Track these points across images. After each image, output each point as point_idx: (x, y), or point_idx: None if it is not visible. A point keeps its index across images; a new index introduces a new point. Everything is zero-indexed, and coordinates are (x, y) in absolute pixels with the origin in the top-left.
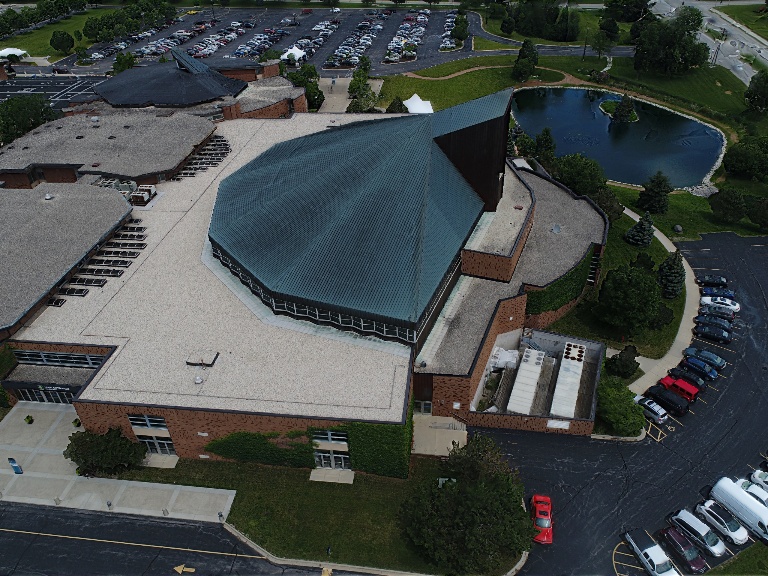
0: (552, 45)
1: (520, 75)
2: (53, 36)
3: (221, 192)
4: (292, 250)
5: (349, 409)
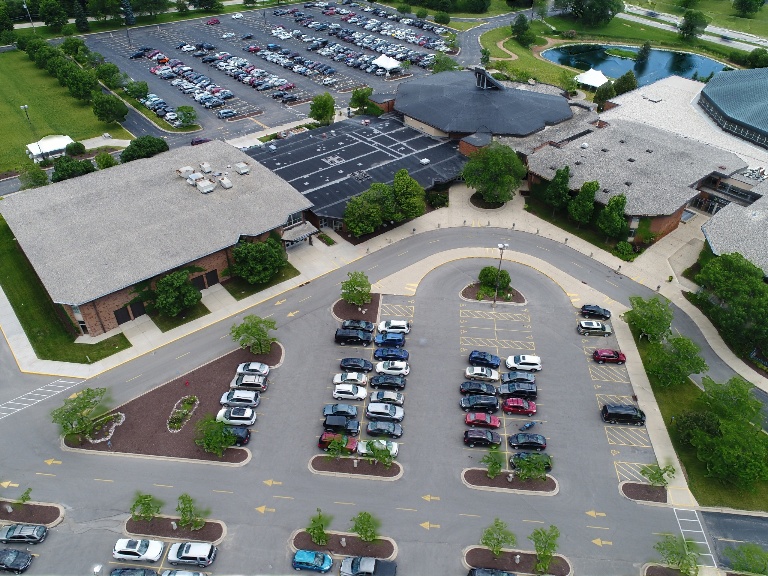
0: (489, 17)
1: (527, 44)
2: (106, 104)
3: None
4: None
5: None
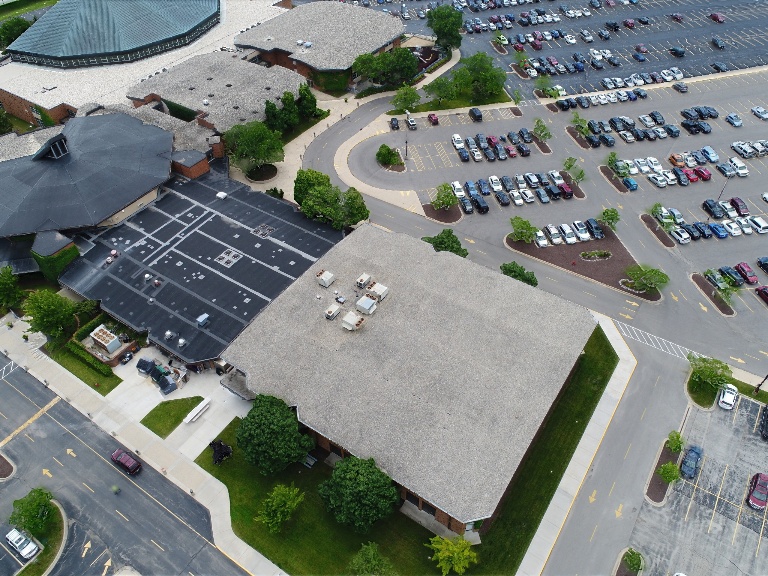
0: None
1: None
2: None
3: (192, 25)
4: None
5: None
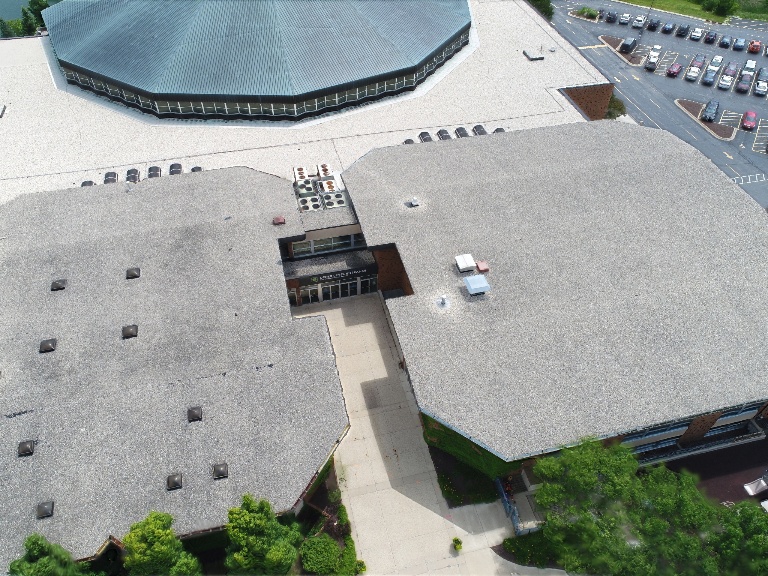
0: None
1: None
2: None
3: (326, 83)
4: (431, 8)
5: (524, 8)
